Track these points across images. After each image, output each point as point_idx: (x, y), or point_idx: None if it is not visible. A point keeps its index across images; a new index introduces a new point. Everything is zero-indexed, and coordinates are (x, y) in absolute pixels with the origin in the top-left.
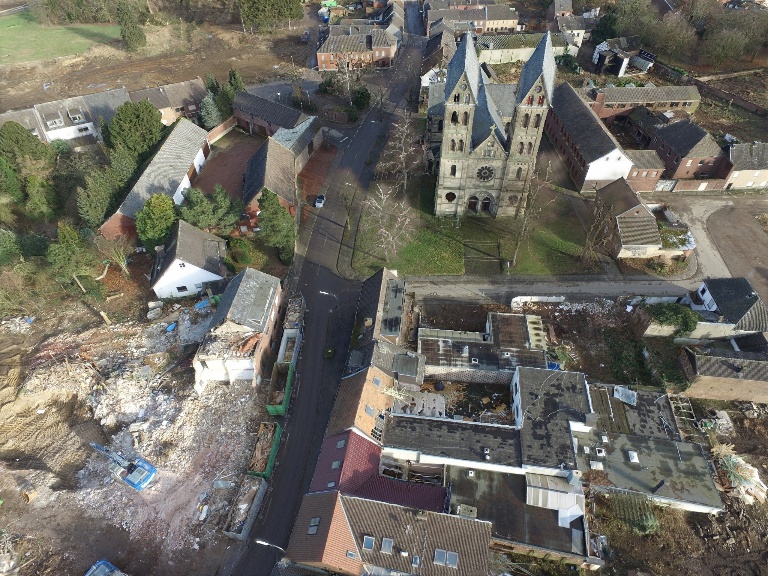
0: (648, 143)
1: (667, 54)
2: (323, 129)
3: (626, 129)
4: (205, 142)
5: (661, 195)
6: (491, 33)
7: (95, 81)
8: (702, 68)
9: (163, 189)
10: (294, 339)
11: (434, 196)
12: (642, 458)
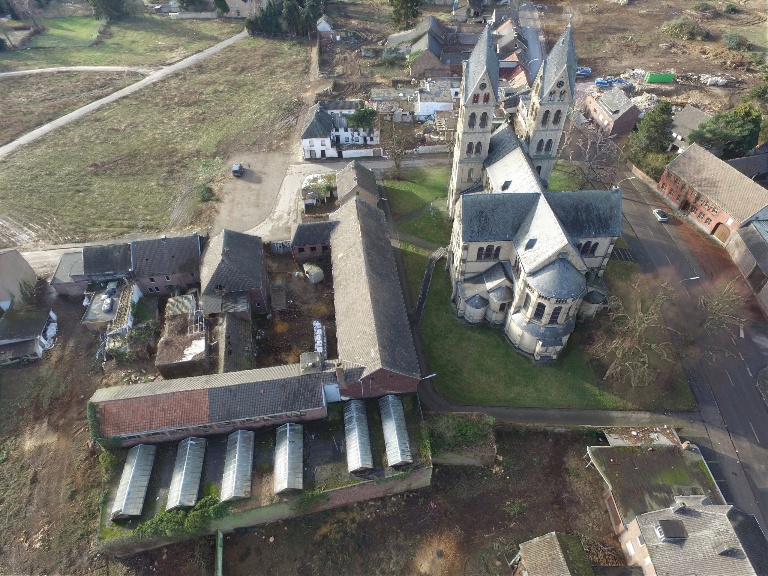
0: None
1: None
2: None
3: None
4: None
5: None
6: None
7: None
8: None
9: None
10: None
11: None
12: (398, 95)
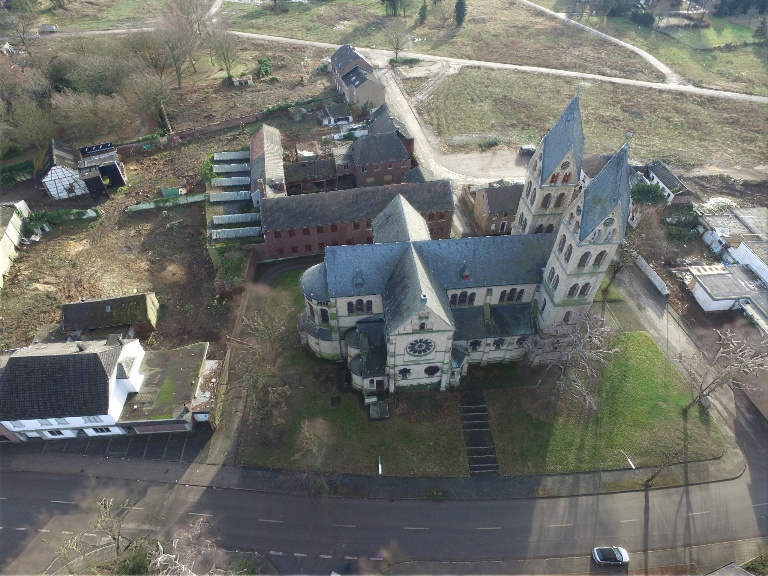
0: (338, 182)
1: (68, 141)
2: None
3: (295, 194)
4: None
5: None
6: None
7: None
8: None
9: None
10: None
11: (523, 368)
12: (767, 230)
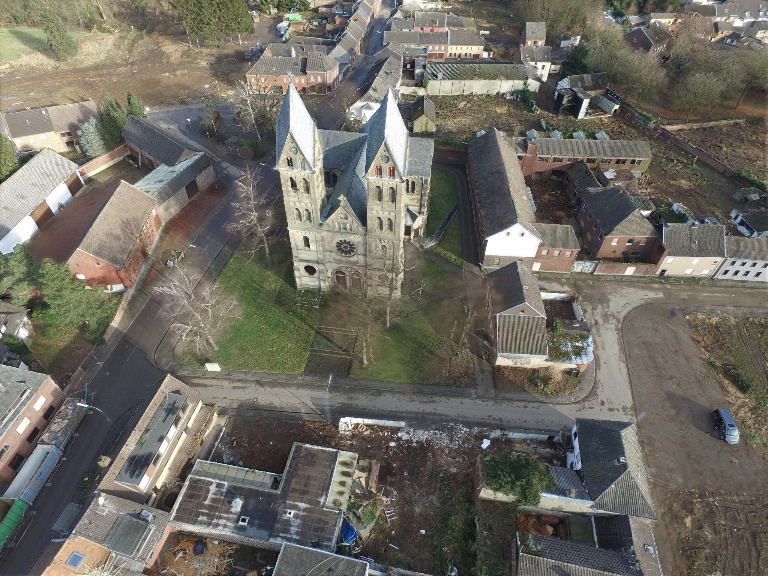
0: None
1: None
2: (222, 165)
3: (564, 186)
4: (74, 176)
5: (578, 278)
6: (449, 60)
7: (7, 93)
8: (677, 113)
9: None
10: None
11: None
12: None
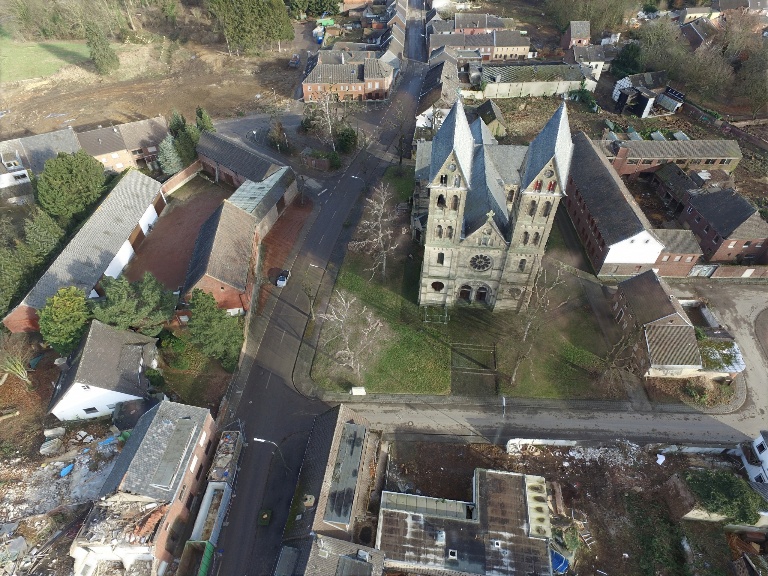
0: (679, 209)
1: None
2: (300, 178)
3: (652, 188)
4: (158, 195)
5: (696, 282)
6: (499, 62)
7: (56, 110)
8: (737, 109)
9: (91, 265)
10: (222, 492)
11: None
12: None
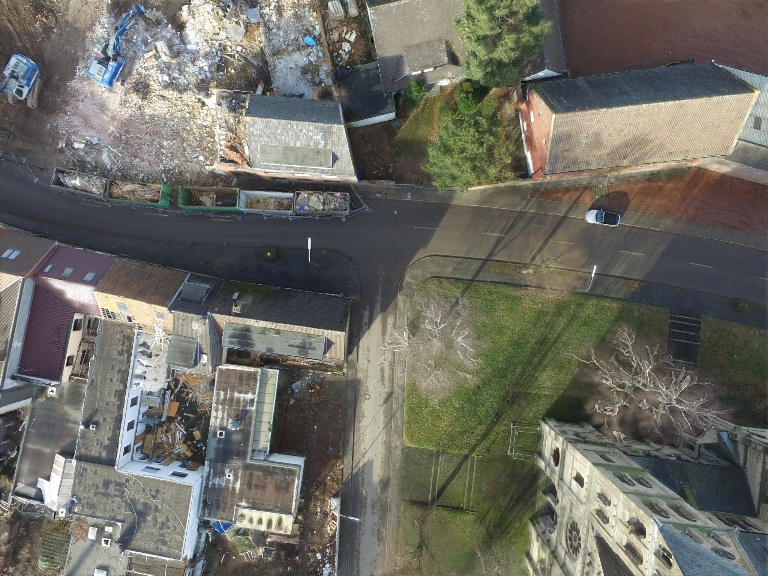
0: None
1: None
2: None
3: None
4: None
5: None
6: None
7: None
8: None
9: None
10: None
11: (601, 425)
12: None
